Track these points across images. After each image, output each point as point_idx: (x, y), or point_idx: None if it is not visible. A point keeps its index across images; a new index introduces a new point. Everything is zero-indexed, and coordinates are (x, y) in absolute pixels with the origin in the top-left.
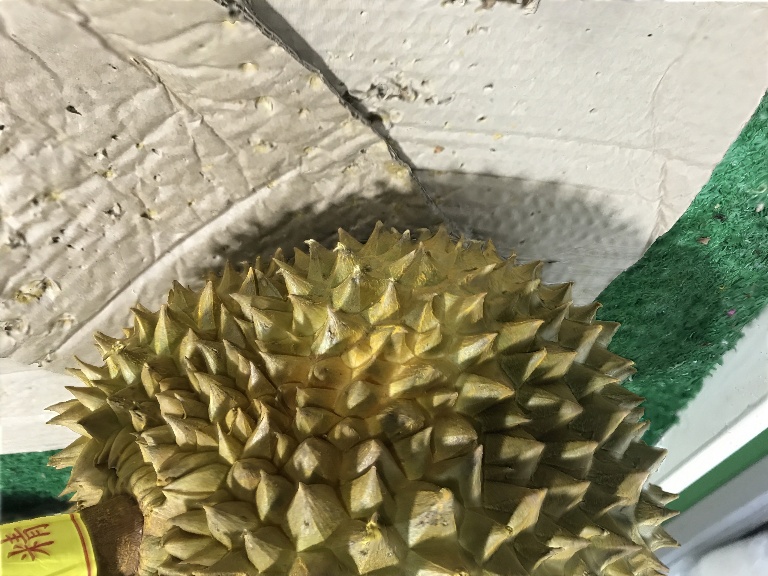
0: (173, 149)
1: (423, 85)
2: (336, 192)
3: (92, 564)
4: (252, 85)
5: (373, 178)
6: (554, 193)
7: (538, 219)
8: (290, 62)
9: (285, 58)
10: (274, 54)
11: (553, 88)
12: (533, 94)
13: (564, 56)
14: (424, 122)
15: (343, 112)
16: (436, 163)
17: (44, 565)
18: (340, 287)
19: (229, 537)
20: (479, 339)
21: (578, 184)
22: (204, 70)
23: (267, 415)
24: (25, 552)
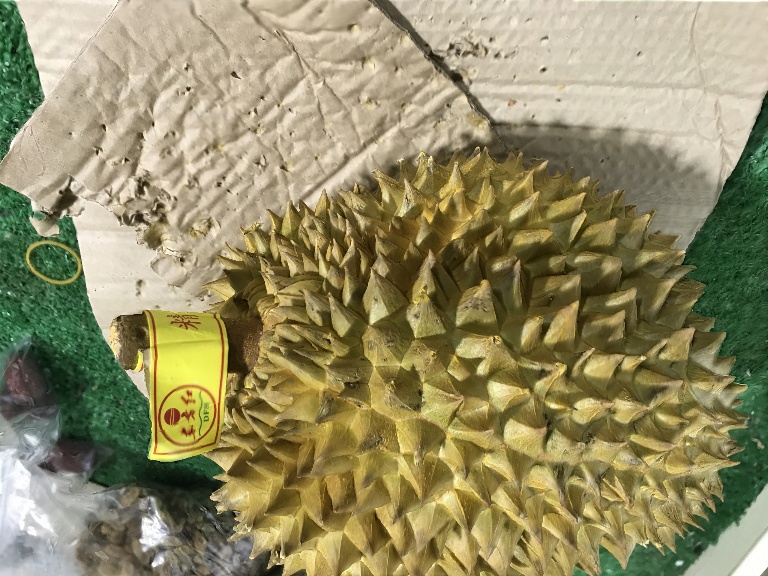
0: (304, 108)
1: (491, 42)
2: (430, 146)
3: (226, 343)
4: (358, 44)
5: (459, 132)
6: (619, 139)
7: (608, 166)
8: (384, 21)
9: (380, 17)
10: (372, 14)
11: (600, 35)
12: (584, 42)
13: (604, 4)
14: (496, 76)
15: (428, 66)
16: (511, 116)
17: (194, 334)
18: (419, 179)
19: (320, 315)
20: (525, 199)
21: (640, 129)
22: (324, 34)
23: (353, 241)
24: (182, 323)
